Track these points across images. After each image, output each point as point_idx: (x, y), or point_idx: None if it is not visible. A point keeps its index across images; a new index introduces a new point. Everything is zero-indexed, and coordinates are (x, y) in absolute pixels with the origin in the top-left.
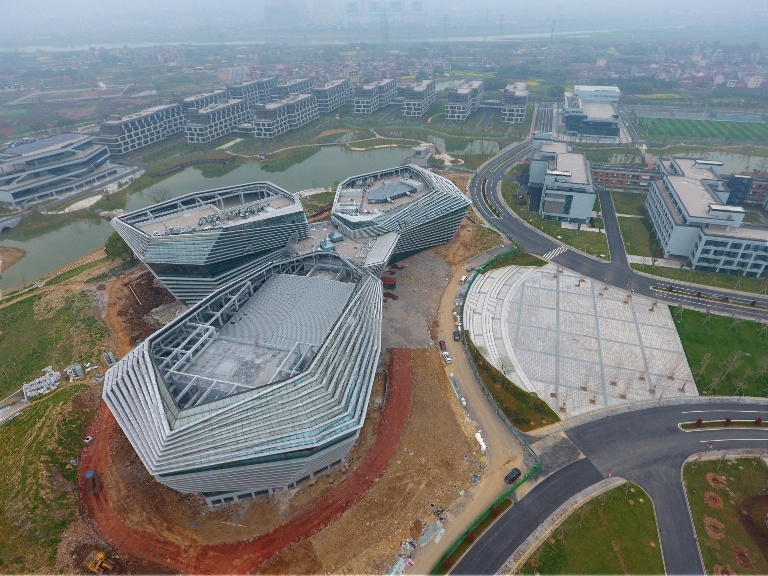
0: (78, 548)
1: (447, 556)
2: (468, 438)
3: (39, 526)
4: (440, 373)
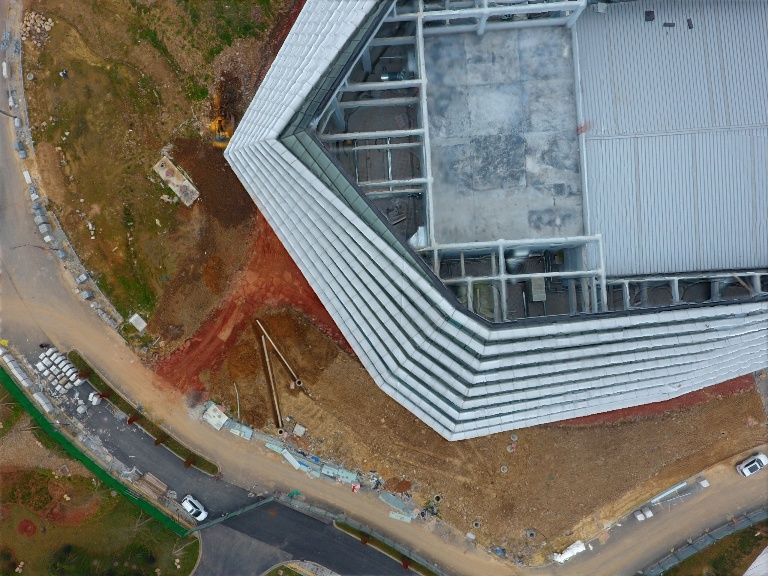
0: (230, 75)
1: (376, 533)
2: (570, 531)
3: (234, 0)
4: (704, 457)
